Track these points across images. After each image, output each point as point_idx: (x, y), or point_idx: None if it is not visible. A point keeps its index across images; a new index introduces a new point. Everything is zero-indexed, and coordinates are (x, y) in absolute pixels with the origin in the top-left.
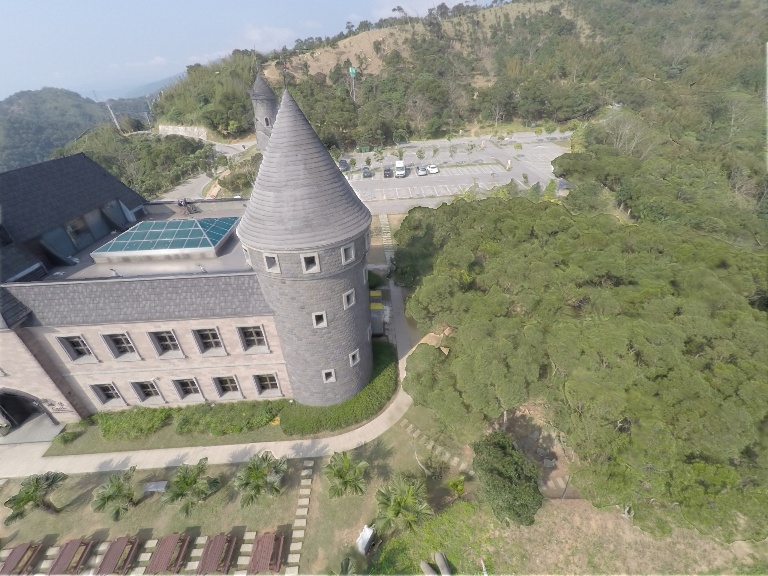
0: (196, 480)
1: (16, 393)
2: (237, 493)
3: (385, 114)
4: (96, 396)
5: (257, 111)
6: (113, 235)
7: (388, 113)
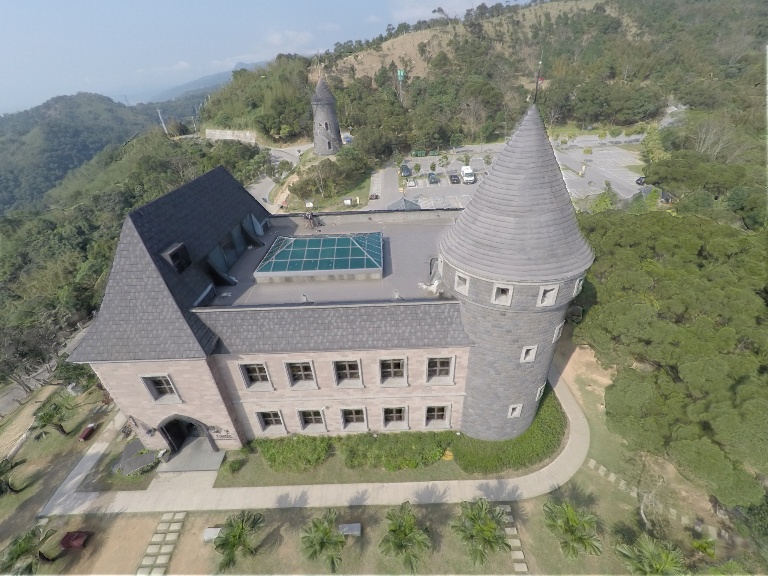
0: (412, 530)
1: (186, 420)
2: (439, 541)
3: (438, 117)
4: (259, 423)
5: (317, 116)
6: (251, 250)
7: (441, 116)
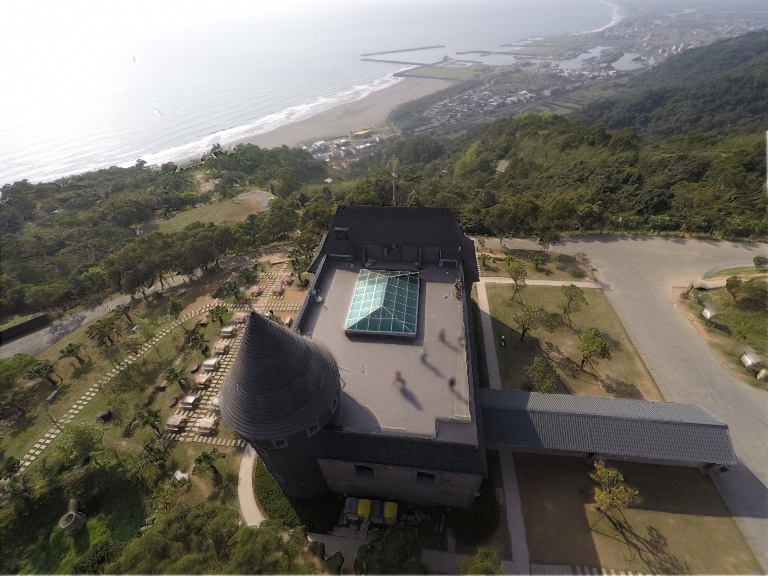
0: None
1: None
2: None
3: None
4: None
5: None
6: (412, 265)
7: None
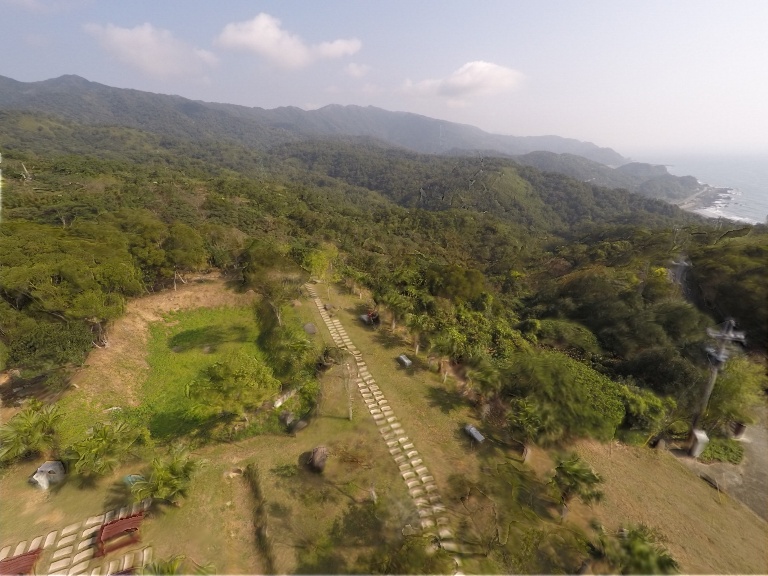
0: None
1: None
2: None
3: None
4: None
5: None
6: None
7: None
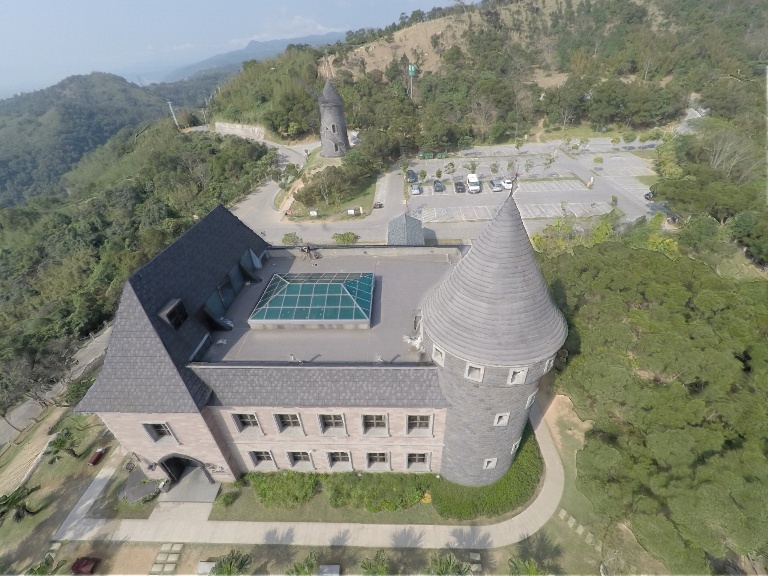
0: None
1: (184, 457)
2: None
3: (447, 117)
4: (251, 460)
5: (324, 117)
6: (248, 287)
7: (451, 116)
